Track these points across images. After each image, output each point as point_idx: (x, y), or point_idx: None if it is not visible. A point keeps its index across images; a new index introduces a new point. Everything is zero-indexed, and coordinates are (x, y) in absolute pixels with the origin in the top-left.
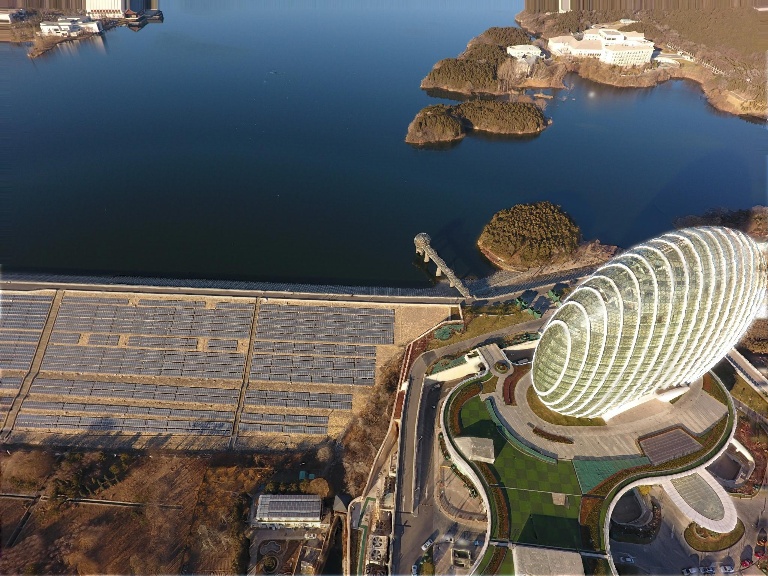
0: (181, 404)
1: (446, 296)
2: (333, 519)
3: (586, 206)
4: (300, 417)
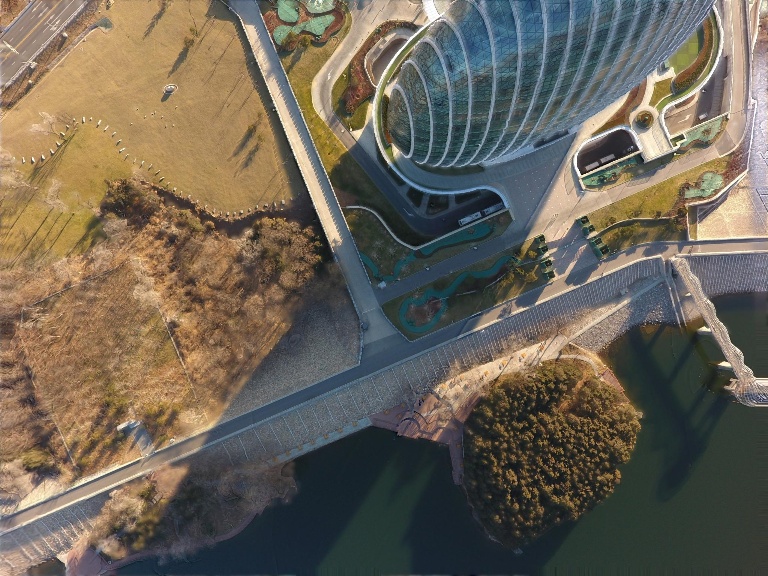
0: None
1: (702, 266)
2: None
3: (414, 569)
4: None
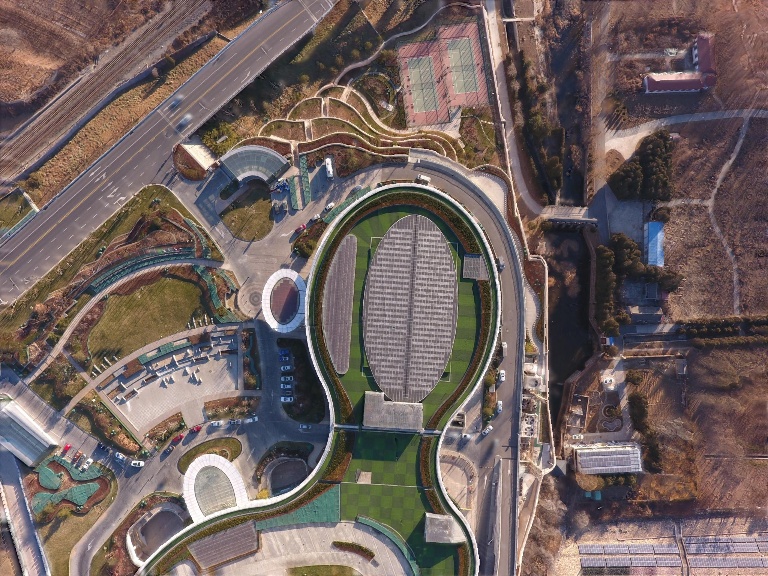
0: (756, 575)
1: None
2: (562, 453)
3: None
4: (614, 565)
